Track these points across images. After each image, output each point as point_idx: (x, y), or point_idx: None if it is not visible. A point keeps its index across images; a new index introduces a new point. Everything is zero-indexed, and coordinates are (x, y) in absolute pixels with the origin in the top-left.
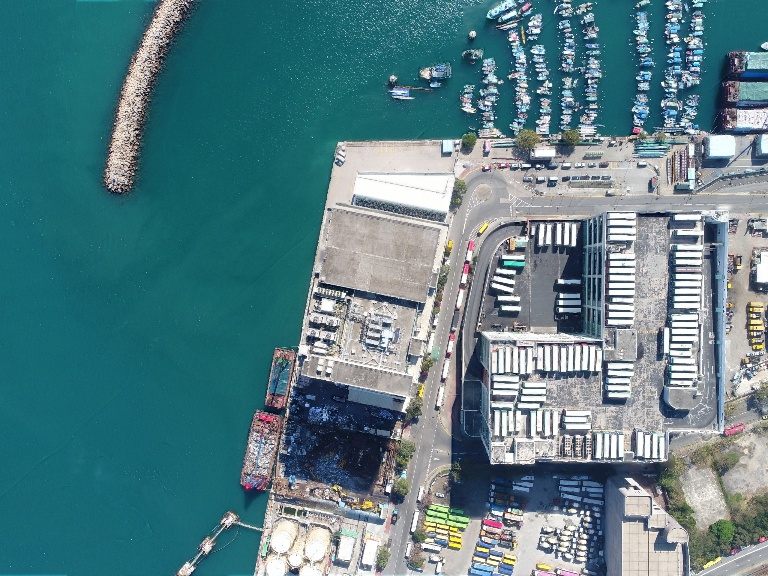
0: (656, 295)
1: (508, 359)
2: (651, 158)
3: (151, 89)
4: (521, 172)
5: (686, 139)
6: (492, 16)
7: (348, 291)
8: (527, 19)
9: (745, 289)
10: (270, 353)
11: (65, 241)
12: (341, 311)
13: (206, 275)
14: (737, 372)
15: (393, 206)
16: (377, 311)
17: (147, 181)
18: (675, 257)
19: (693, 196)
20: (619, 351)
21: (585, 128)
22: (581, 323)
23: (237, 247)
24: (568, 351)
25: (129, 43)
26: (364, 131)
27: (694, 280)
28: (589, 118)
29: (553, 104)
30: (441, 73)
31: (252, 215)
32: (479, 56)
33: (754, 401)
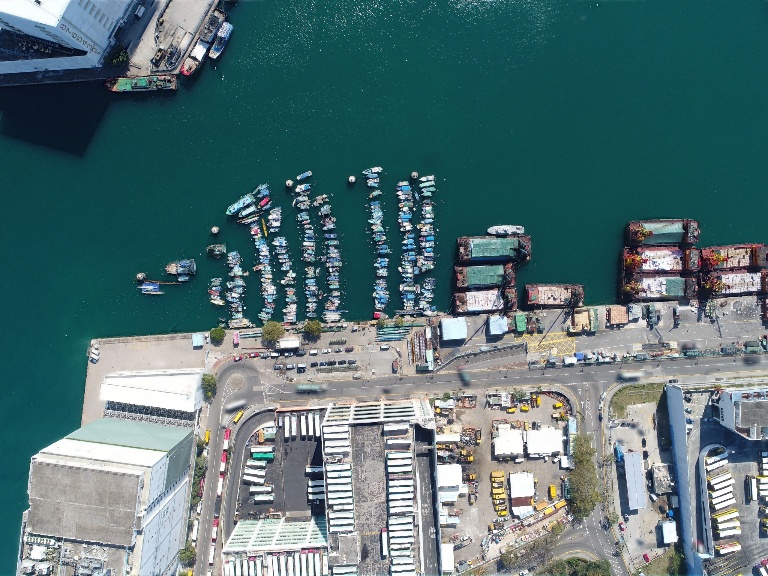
0: (376, 498)
1: (238, 571)
2: (393, 341)
3: None
4: (271, 360)
5: (424, 321)
6: (232, 212)
7: (57, 538)
8: (267, 213)
9: (488, 459)
10: None
11: None
12: (53, 555)
13: None
14: (485, 538)
15: (144, 405)
16: (88, 554)
17: None
18: (388, 465)
19: (434, 375)
20: (342, 556)
21: (330, 314)
22: None
23: (0, 446)
24: (294, 559)
25: None
26: (117, 327)
27: (406, 486)
28: (333, 305)
29: (298, 292)
30: (186, 269)
31: (13, 414)
32: (222, 251)
33: (503, 563)
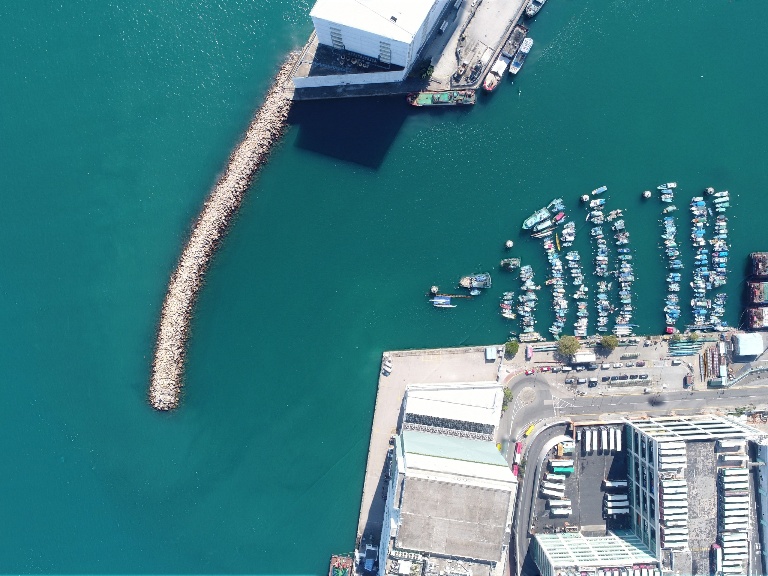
0: (706, 515)
1: None
2: (684, 356)
3: (192, 306)
4: (563, 374)
5: (716, 336)
6: (528, 226)
7: (424, 553)
8: (561, 227)
9: None
10: (326, 559)
11: (118, 474)
12: (417, 570)
13: (258, 486)
14: None
15: (443, 418)
16: (453, 569)
17: (193, 396)
18: (723, 481)
19: (725, 390)
20: (676, 572)
21: (621, 329)
22: (629, 520)
23: (288, 458)
24: (628, 575)
25: (167, 261)
26: (408, 340)
27: (742, 502)
28: (624, 319)
29: (589, 307)
30: (481, 283)
31: (301, 426)
32: (517, 265)
33: None
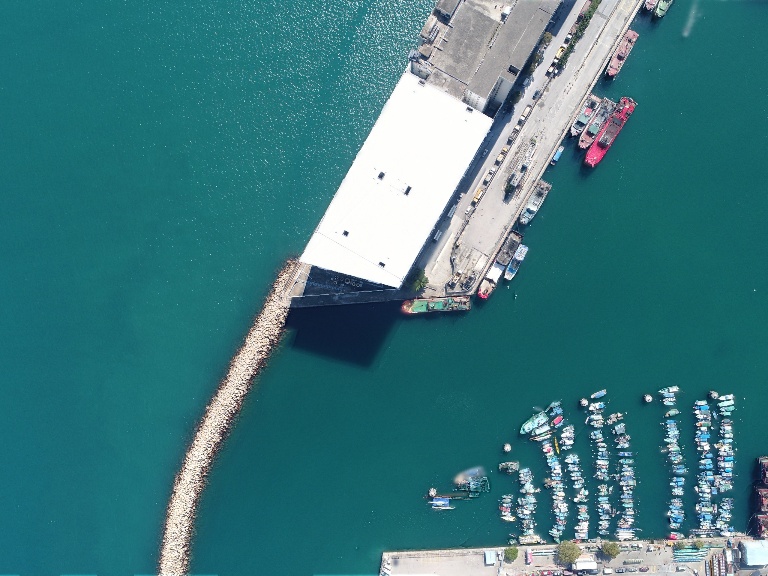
0: None
1: None
2: (690, 562)
3: (196, 506)
4: None
5: (723, 542)
6: (525, 431)
7: None
8: (560, 431)
9: None
10: None
11: None
12: None
13: None
14: None
15: None
16: None
17: None
18: None
19: None
20: None
21: (623, 532)
22: None
23: None
24: None
25: (172, 462)
26: (407, 542)
27: None
28: (626, 523)
29: (590, 510)
30: (479, 487)
31: None
32: (515, 470)
33: None
